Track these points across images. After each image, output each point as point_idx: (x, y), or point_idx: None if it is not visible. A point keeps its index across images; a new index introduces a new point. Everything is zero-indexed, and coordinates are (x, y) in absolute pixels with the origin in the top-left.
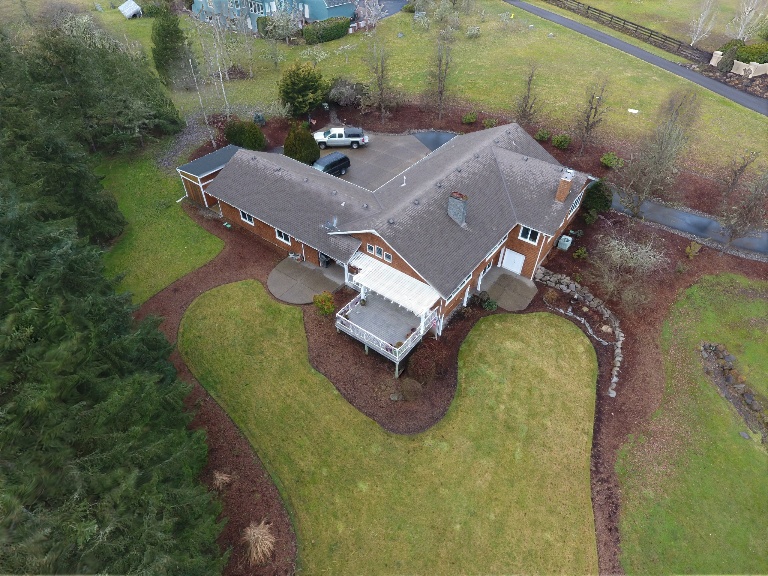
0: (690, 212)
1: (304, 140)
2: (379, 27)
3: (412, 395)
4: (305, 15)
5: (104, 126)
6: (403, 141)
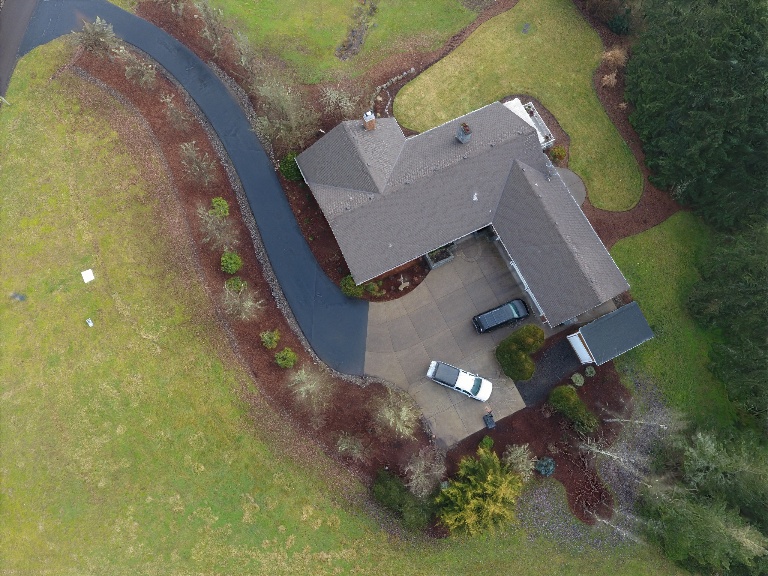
0: (217, 140)
1: None
2: None
3: None
4: None
5: None
6: (384, 361)
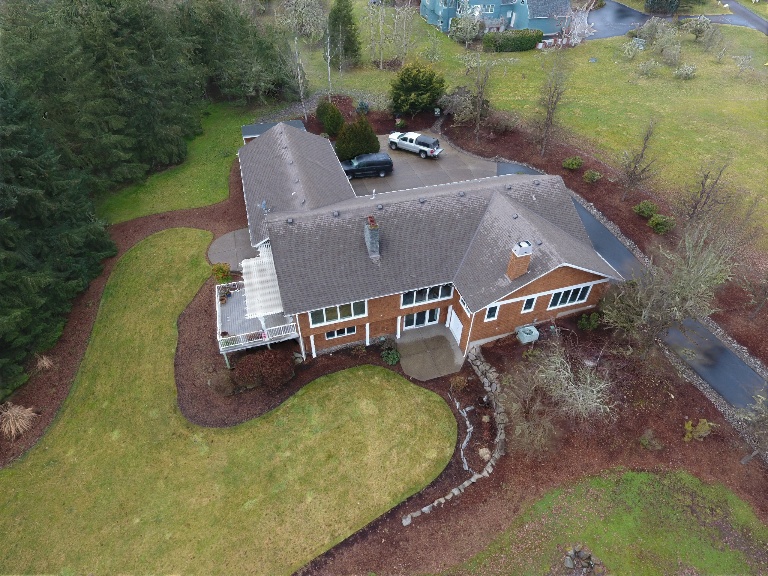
0: None
1: (357, 133)
2: (579, 48)
3: (213, 388)
4: (511, 23)
5: (234, 81)
6: (479, 166)
